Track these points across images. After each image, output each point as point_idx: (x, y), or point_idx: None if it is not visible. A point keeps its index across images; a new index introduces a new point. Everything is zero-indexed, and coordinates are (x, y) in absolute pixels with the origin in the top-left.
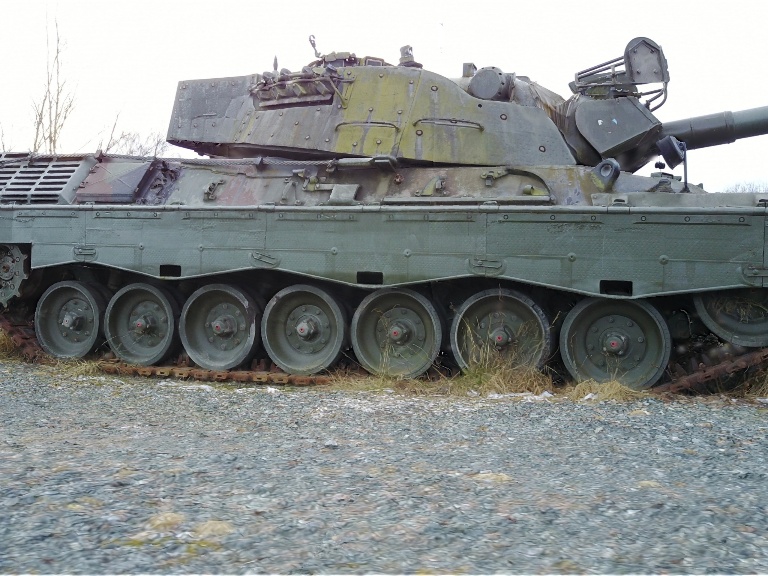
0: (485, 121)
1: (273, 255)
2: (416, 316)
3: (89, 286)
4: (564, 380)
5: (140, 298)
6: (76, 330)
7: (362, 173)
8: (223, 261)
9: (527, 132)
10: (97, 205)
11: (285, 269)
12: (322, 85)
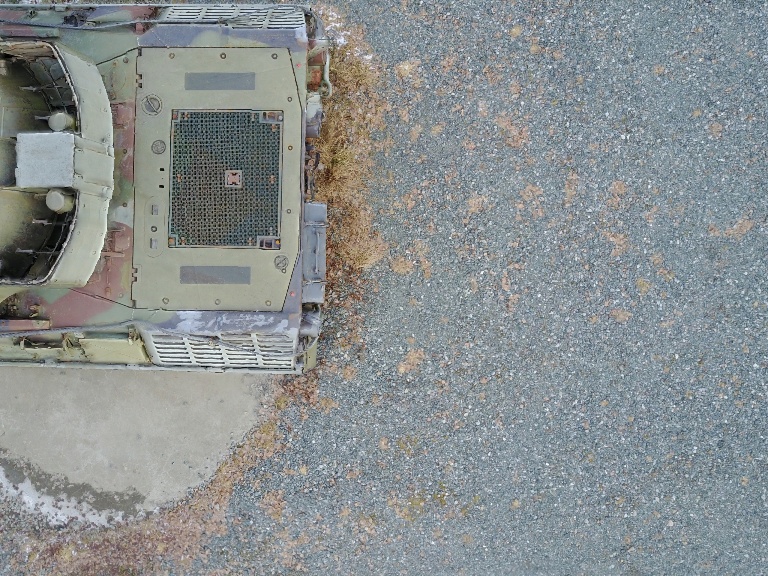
0: None
1: None
2: None
3: None
4: None
5: None
6: None
7: None
8: None
9: None
10: (133, 4)
11: None
12: None
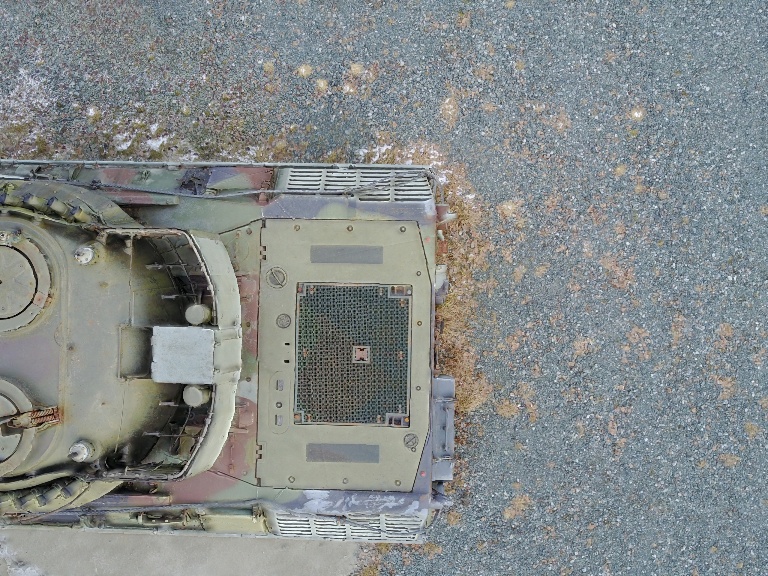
0: None
1: None
2: None
3: None
4: None
5: None
6: None
7: None
8: None
9: None
10: (248, 163)
11: None
12: None
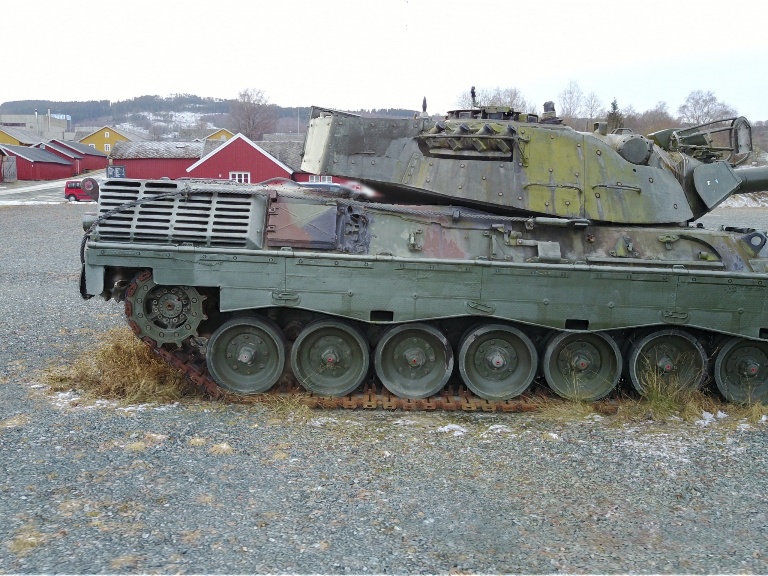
0: (640, 184)
1: (488, 304)
2: (594, 348)
3: (266, 322)
4: (716, 397)
5: (323, 333)
6: (249, 364)
7: (554, 230)
8: (438, 308)
9: (667, 193)
10: (298, 252)
11: (500, 316)
12: (504, 143)
